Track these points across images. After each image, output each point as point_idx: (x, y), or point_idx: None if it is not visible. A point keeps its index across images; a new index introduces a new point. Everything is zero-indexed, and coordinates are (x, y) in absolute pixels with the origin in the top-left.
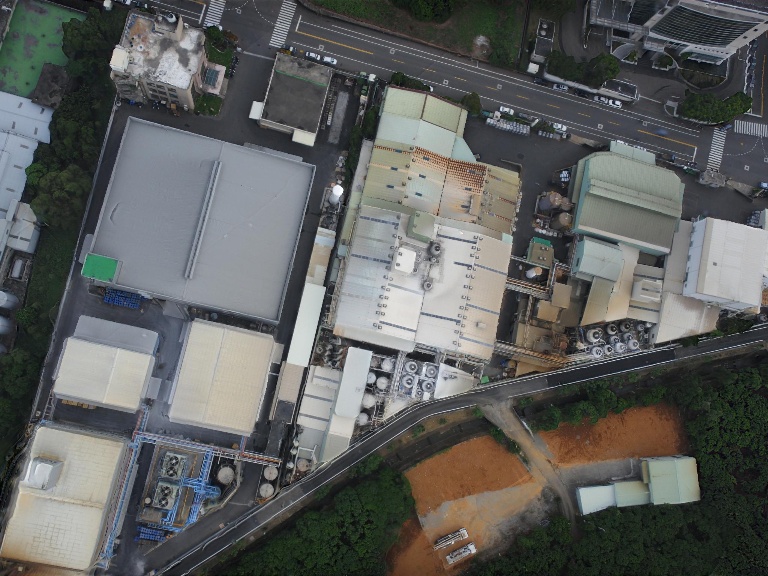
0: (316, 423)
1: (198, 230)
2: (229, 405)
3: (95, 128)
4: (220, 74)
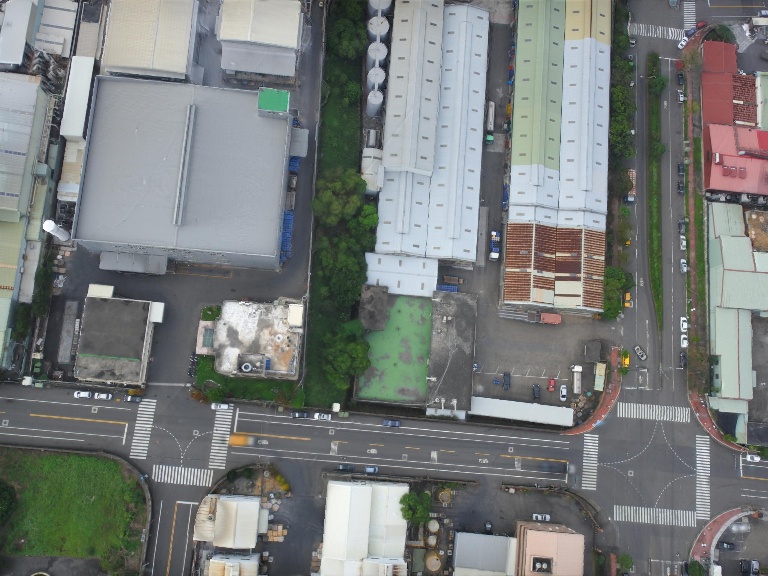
0: (58, 4)
1: (188, 152)
2: (140, 2)
3: (323, 269)
4: (201, 344)
